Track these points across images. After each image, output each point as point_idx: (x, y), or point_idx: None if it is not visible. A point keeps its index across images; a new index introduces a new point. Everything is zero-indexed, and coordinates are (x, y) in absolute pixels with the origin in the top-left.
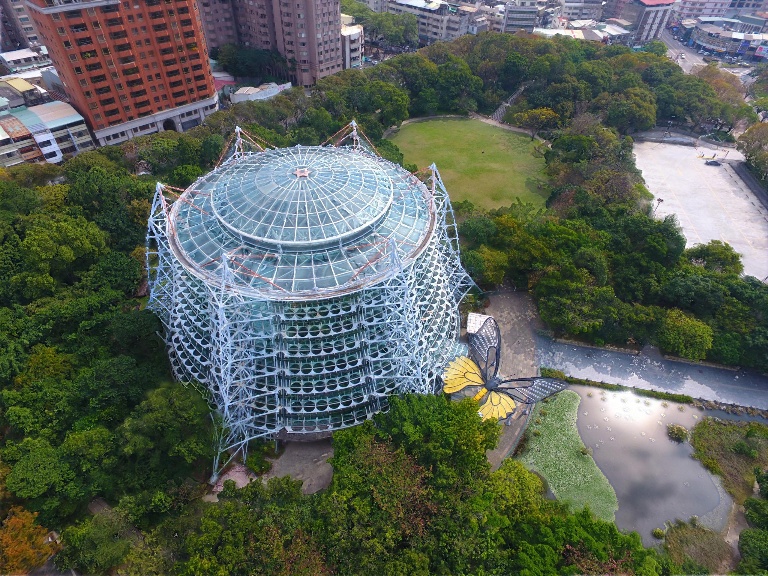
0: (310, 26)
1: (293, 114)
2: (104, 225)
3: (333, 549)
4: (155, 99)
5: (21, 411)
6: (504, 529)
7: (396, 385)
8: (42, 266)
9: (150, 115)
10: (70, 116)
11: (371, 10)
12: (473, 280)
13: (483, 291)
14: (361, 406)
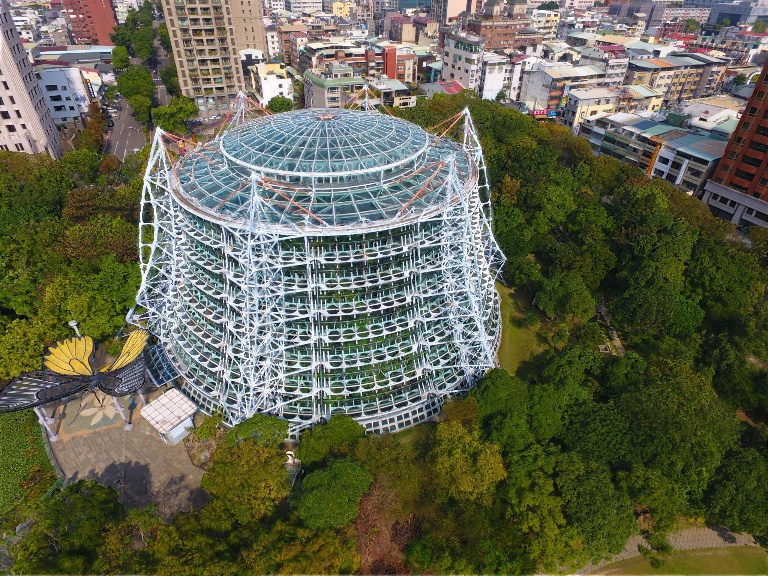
0: None
1: None
2: (482, 171)
3: None
4: None
5: None
6: (7, 317)
7: None
8: None
9: None
10: (711, 154)
11: None
12: None
13: None
14: None
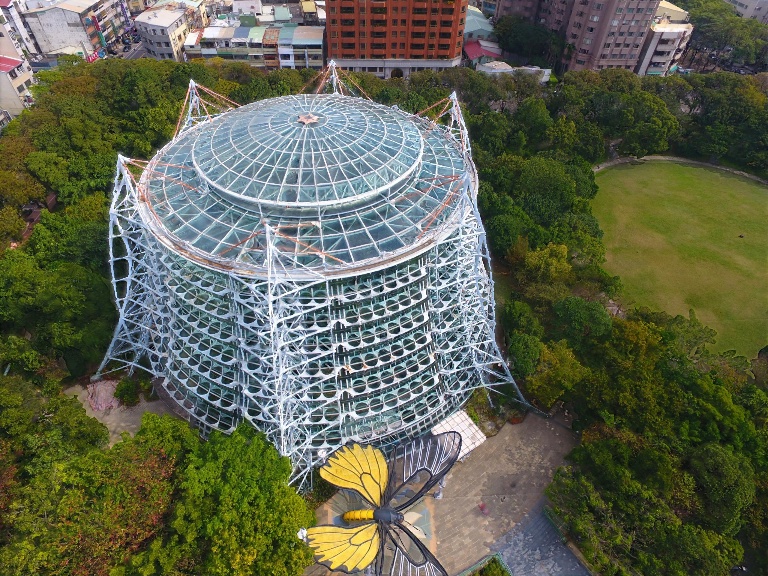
0: (609, 9)
1: (511, 98)
2: None
3: (7, 516)
4: (393, 45)
5: (43, 231)
6: None
7: (272, 419)
8: (147, 134)
9: (382, 59)
10: (315, 39)
11: (738, 15)
12: (513, 376)
13: (528, 401)
14: (230, 413)
